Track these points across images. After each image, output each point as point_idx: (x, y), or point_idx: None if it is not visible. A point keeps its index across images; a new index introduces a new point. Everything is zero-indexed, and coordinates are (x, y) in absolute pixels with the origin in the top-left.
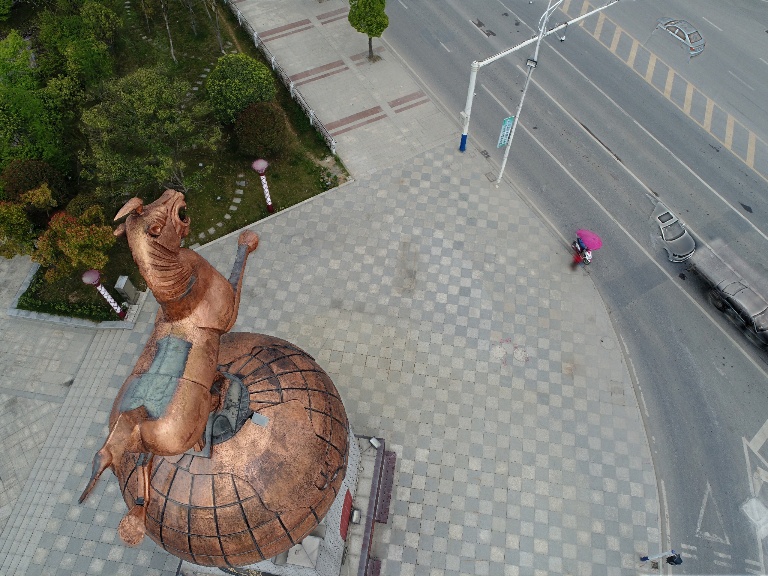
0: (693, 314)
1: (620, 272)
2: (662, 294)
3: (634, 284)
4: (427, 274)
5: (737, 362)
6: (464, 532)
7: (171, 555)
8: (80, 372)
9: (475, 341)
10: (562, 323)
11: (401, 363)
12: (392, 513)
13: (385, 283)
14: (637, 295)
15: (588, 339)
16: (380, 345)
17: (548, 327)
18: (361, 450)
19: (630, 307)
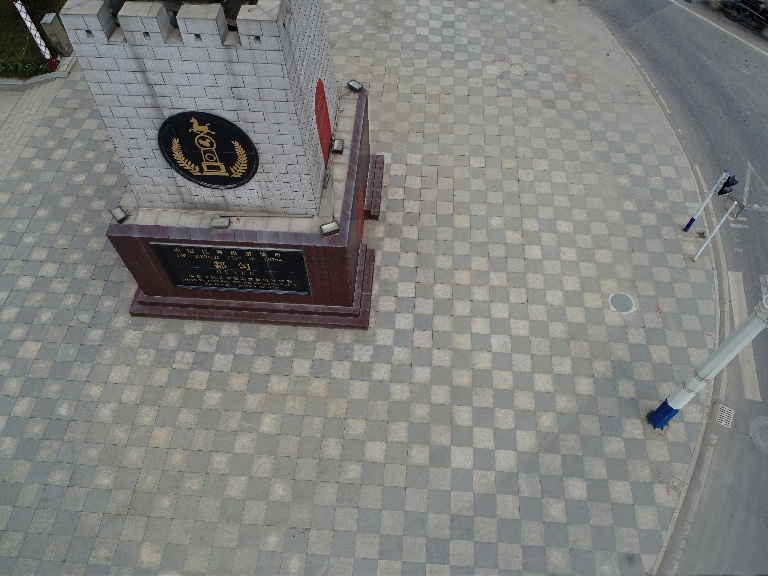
0: (705, 29)
1: (619, 2)
2: (668, 15)
3: (636, 10)
4: (404, 13)
5: (761, 63)
6: (472, 220)
7: (117, 266)
8: (5, 125)
9: (465, 62)
10: (561, 43)
11: (382, 85)
12: (384, 210)
13: (357, 23)
14: (641, 18)
15: (592, 54)
16: (356, 72)
17: (546, 47)
18: (339, 94)
19: (635, 28)
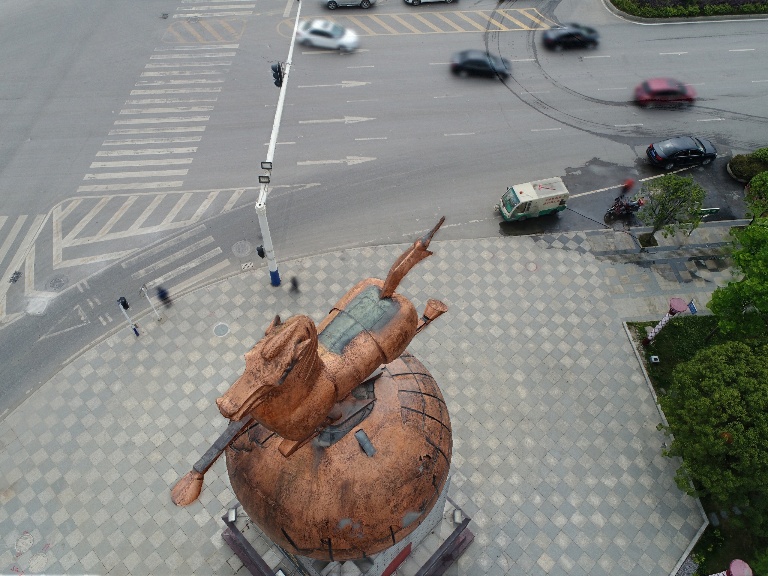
0: None
1: None
2: None
3: None
4: None
5: None
6: None
7: None
8: None
9: None
10: None
11: None
12: None
13: None
14: None
15: None
16: None
17: None
18: (249, 519)
19: None
